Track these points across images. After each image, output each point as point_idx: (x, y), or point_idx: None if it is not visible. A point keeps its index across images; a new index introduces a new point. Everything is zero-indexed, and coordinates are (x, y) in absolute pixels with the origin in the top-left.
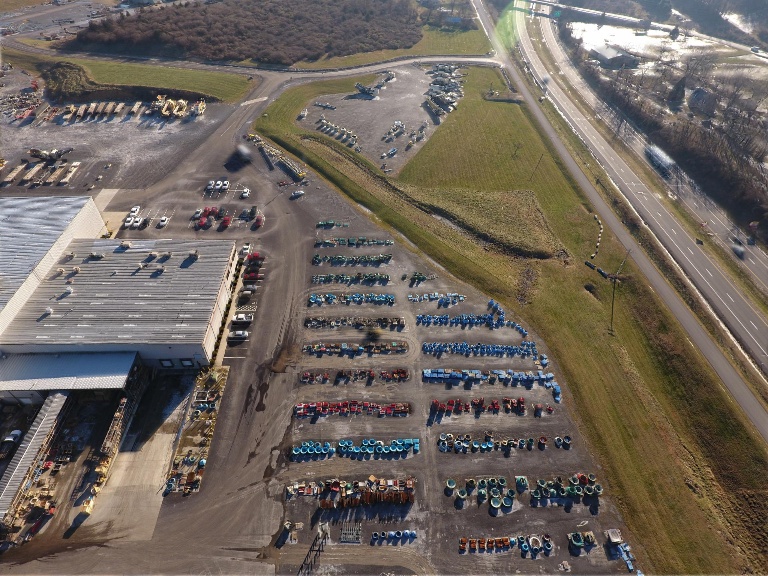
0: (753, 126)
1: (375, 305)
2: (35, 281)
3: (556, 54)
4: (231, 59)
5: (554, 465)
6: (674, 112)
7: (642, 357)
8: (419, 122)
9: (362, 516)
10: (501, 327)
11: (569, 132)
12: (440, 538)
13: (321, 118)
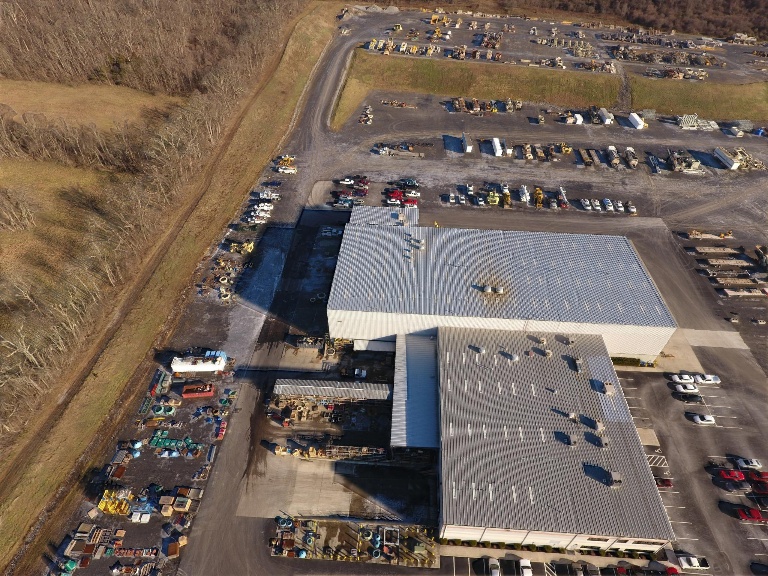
0: None
1: None
2: (520, 326)
3: None
4: None
5: None
6: None
7: None
8: None
9: None
10: None
11: None
12: None
13: None
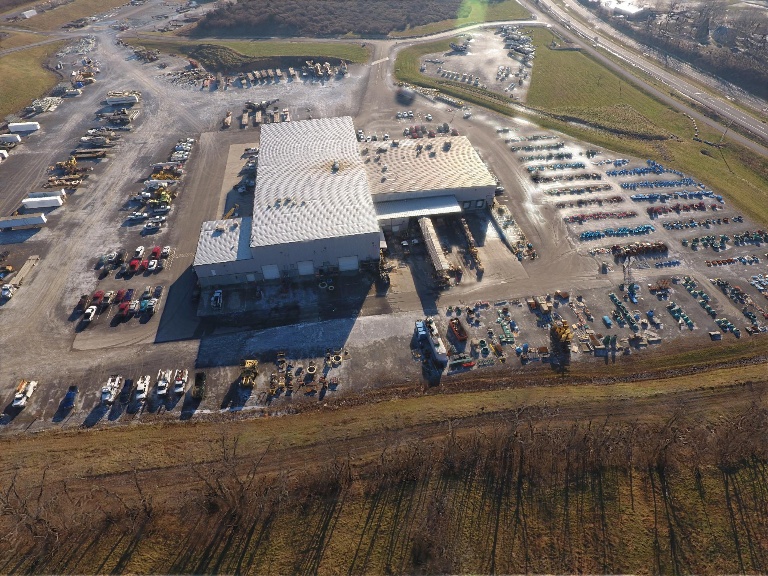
0: (767, 50)
1: (573, 169)
2: None
3: (584, 14)
4: (337, 33)
5: (739, 229)
6: (706, 45)
7: (759, 183)
8: (515, 67)
9: (643, 258)
10: (663, 173)
11: (630, 66)
12: (694, 262)
13: (439, 69)
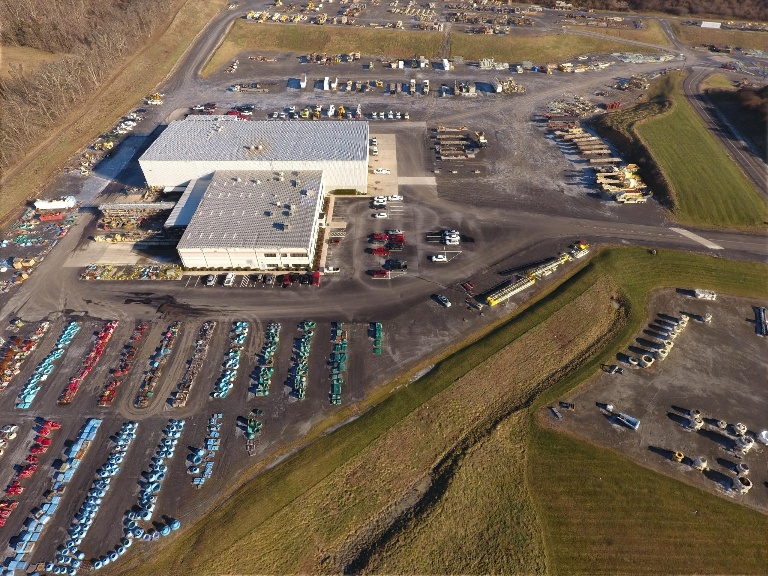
0: None
1: (217, 379)
2: (268, 166)
3: None
4: None
5: None
6: None
7: None
8: None
9: None
10: (124, 528)
11: None
12: None
13: (703, 316)
